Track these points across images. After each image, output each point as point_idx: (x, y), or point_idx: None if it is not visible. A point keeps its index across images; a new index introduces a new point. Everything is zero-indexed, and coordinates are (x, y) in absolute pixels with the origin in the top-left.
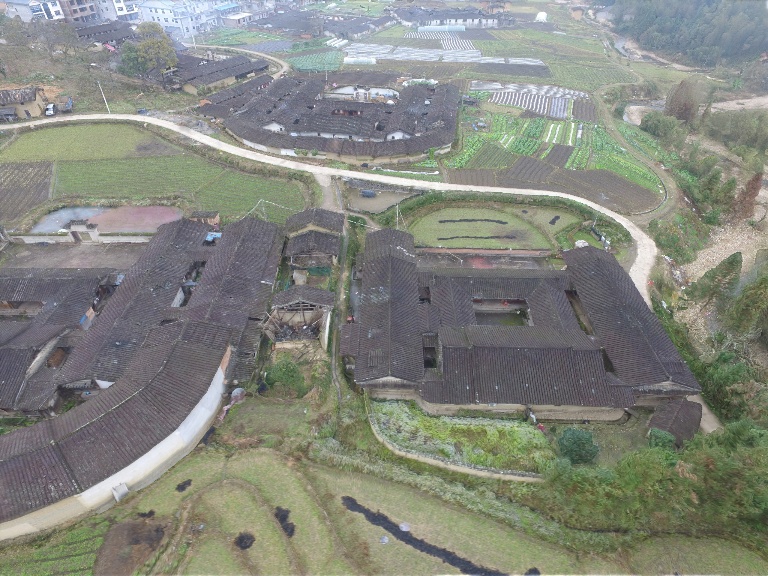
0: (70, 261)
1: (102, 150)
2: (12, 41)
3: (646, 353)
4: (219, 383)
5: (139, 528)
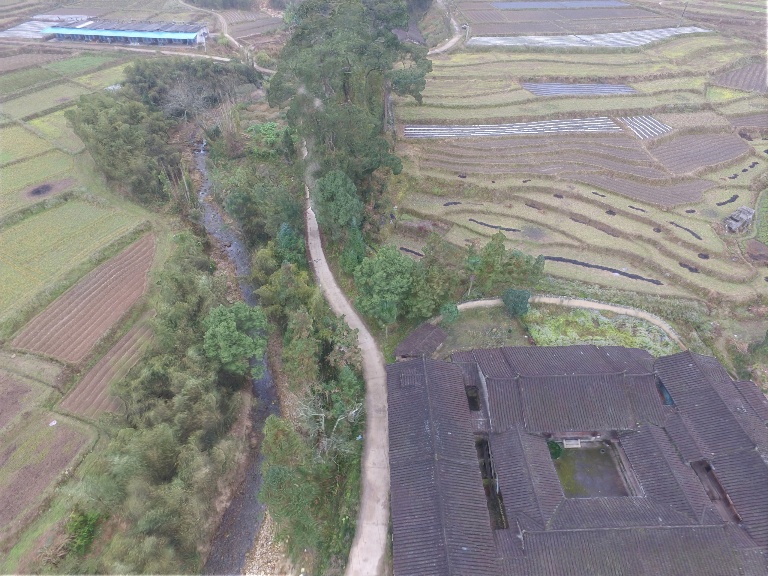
0: None
1: None
2: None
3: (434, 386)
4: None
5: (767, 259)
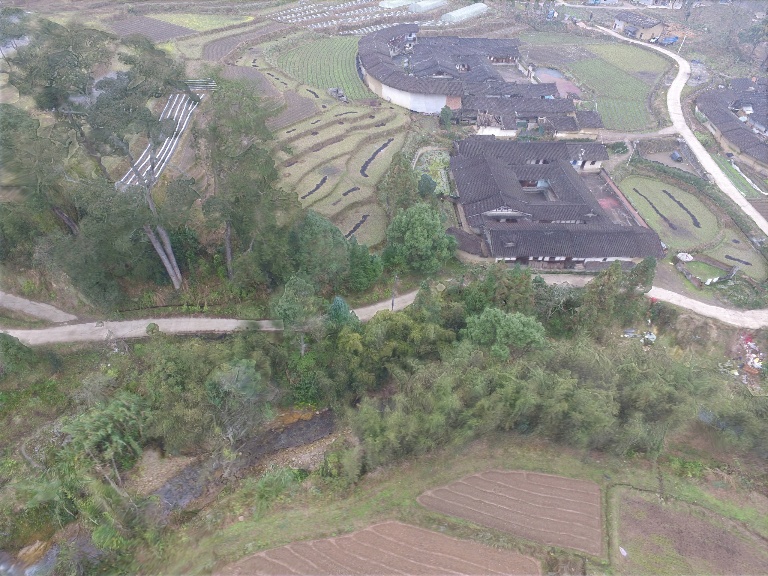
0: (512, 79)
1: (626, 64)
2: None
3: None
4: (440, 108)
5: (375, 102)
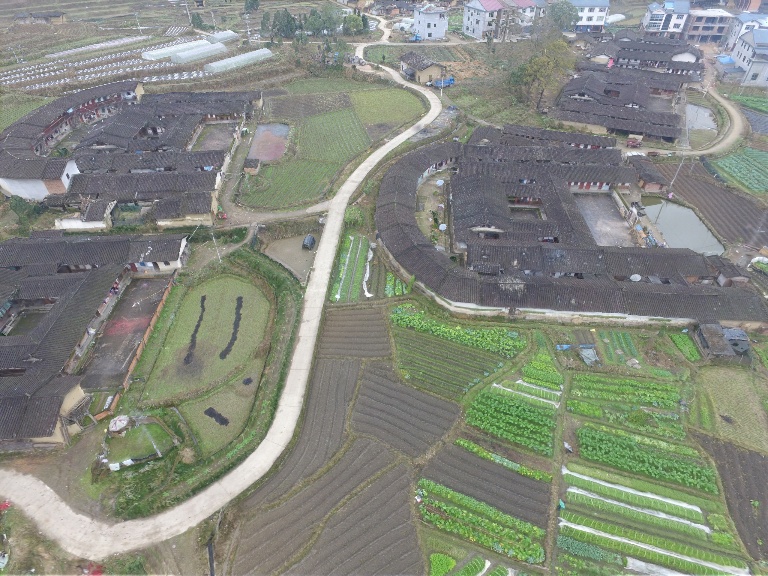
0: (217, 141)
1: (374, 114)
2: (577, 37)
3: None
4: (43, 193)
5: None
